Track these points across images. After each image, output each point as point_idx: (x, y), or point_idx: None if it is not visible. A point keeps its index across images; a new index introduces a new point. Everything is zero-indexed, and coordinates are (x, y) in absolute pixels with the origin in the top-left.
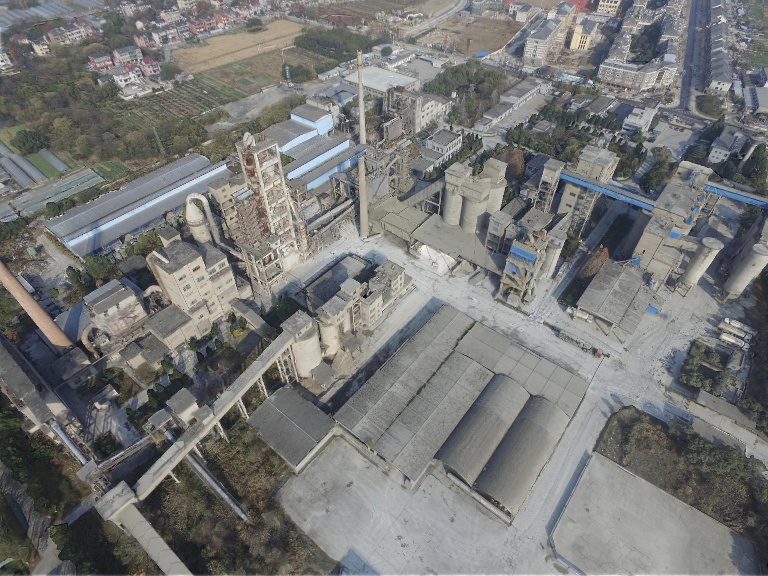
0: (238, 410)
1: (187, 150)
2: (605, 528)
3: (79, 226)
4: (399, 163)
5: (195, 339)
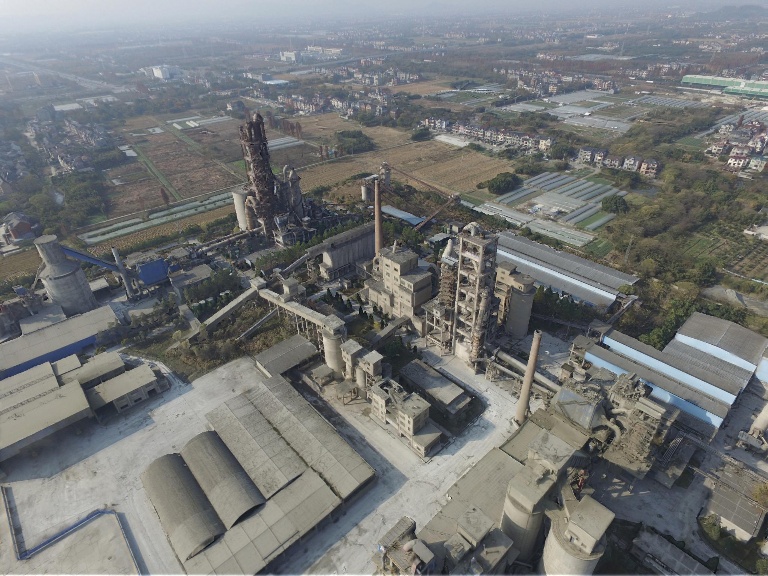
0: None
1: (650, 277)
2: (87, 567)
3: (502, 243)
4: (628, 421)
5: (382, 310)
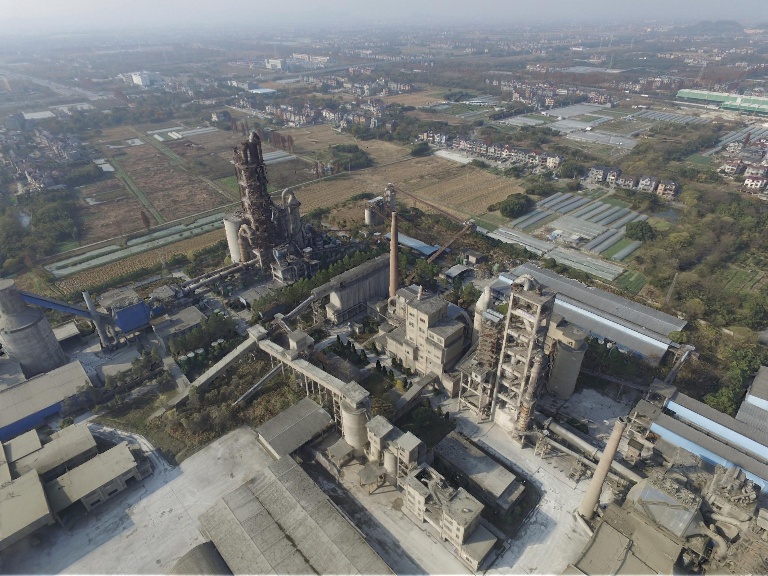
0: None
1: (697, 318)
2: None
3: None
4: (741, 536)
5: (402, 363)
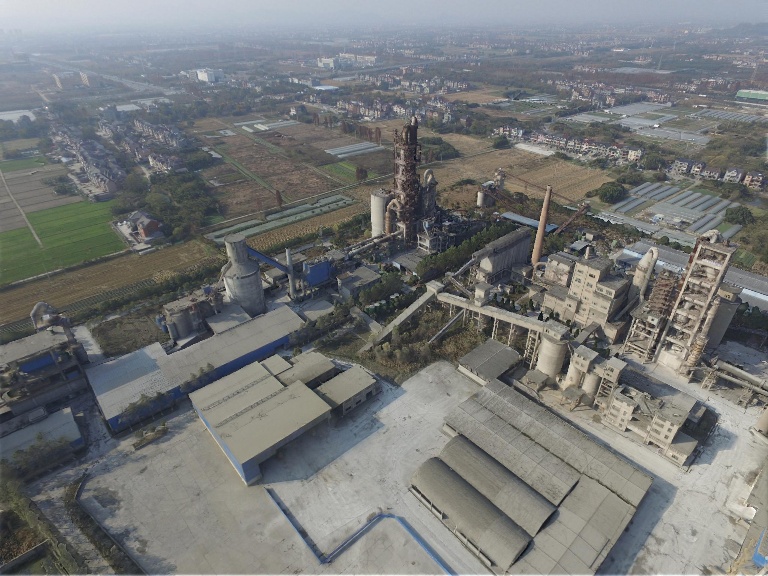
0: None
1: None
2: (396, 572)
3: None
4: None
5: (559, 317)
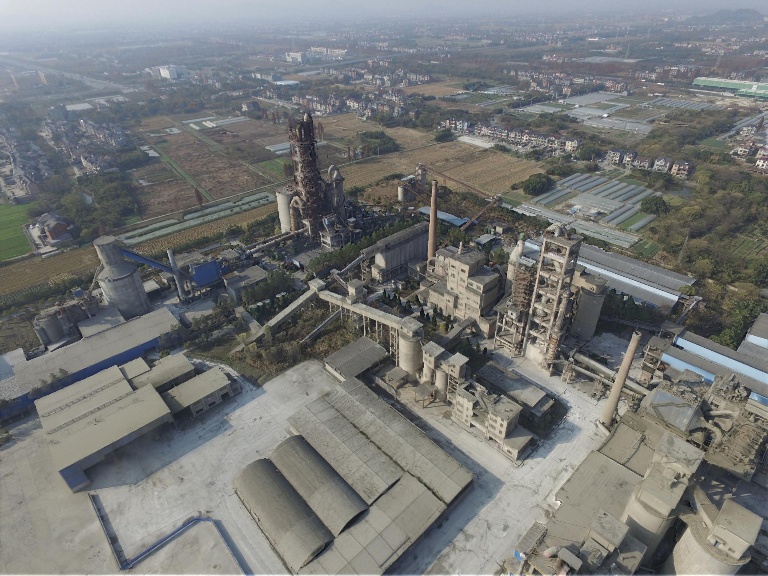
0: None
1: (705, 278)
2: None
3: None
4: (733, 423)
5: (442, 312)
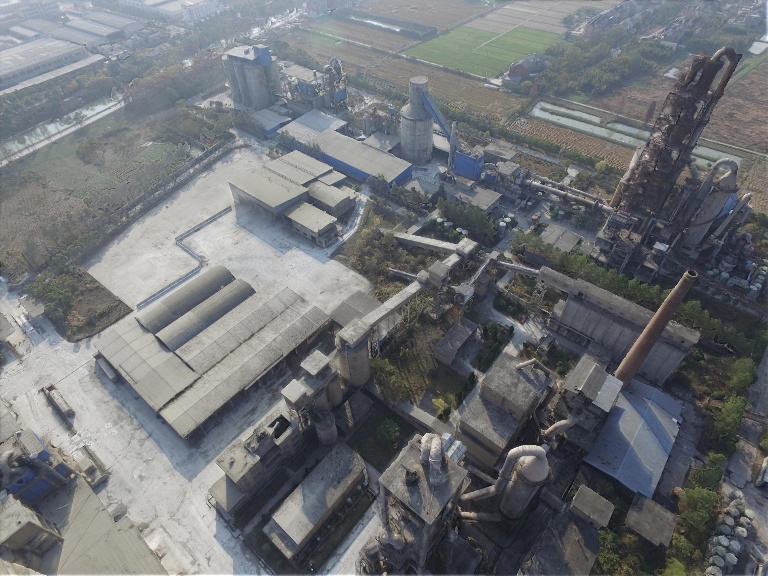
0: (415, 331)
1: None
2: (162, 272)
3: None
4: None
5: None
